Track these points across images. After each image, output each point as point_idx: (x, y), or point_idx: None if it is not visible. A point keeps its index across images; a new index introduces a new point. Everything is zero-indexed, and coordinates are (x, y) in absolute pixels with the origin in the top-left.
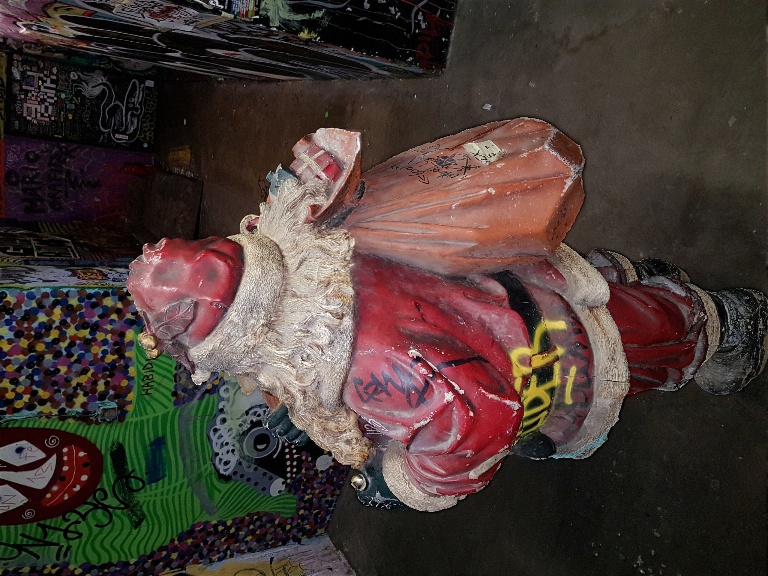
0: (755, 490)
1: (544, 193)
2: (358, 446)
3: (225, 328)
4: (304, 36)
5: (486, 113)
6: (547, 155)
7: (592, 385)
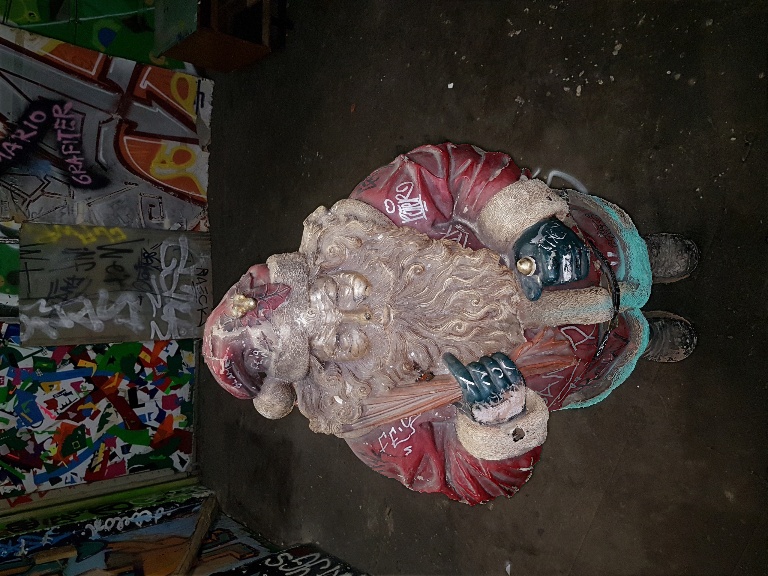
0: None
1: None
2: None
3: None
4: None
5: (512, 568)
6: None
7: None
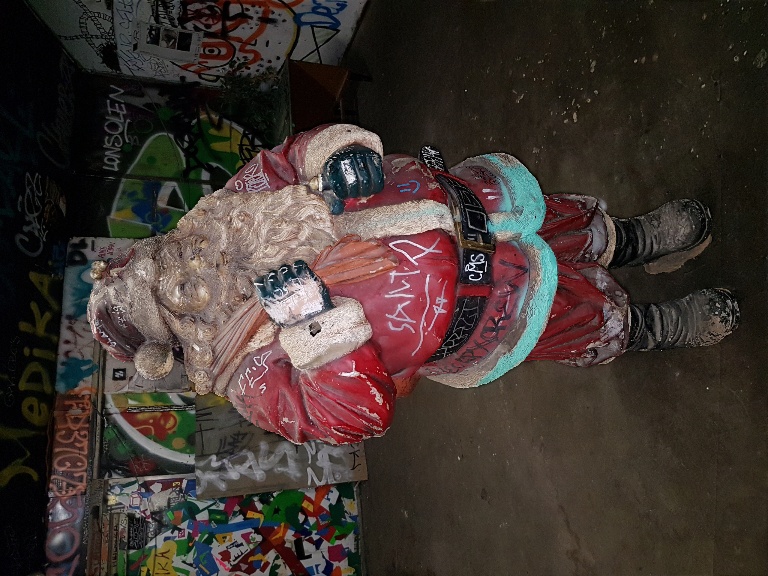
0: (766, 114)
1: None
2: None
3: None
4: None
5: None
6: None
7: None
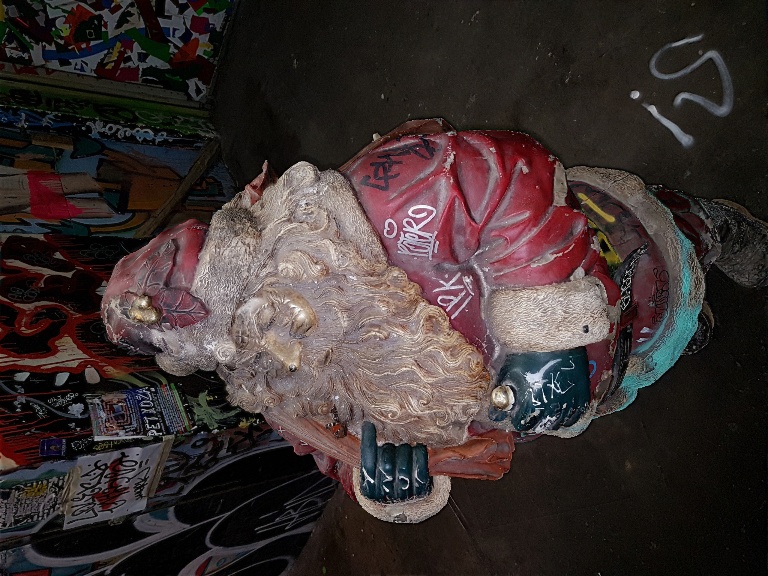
0: None
1: (428, 129)
2: (453, 331)
3: (213, 236)
4: (244, 425)
5: None
6: (411, 123)
7: (611, 197)
